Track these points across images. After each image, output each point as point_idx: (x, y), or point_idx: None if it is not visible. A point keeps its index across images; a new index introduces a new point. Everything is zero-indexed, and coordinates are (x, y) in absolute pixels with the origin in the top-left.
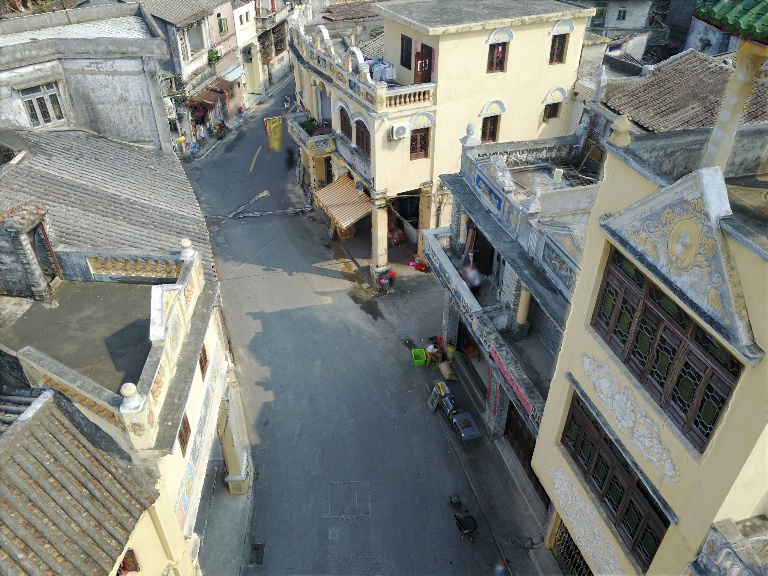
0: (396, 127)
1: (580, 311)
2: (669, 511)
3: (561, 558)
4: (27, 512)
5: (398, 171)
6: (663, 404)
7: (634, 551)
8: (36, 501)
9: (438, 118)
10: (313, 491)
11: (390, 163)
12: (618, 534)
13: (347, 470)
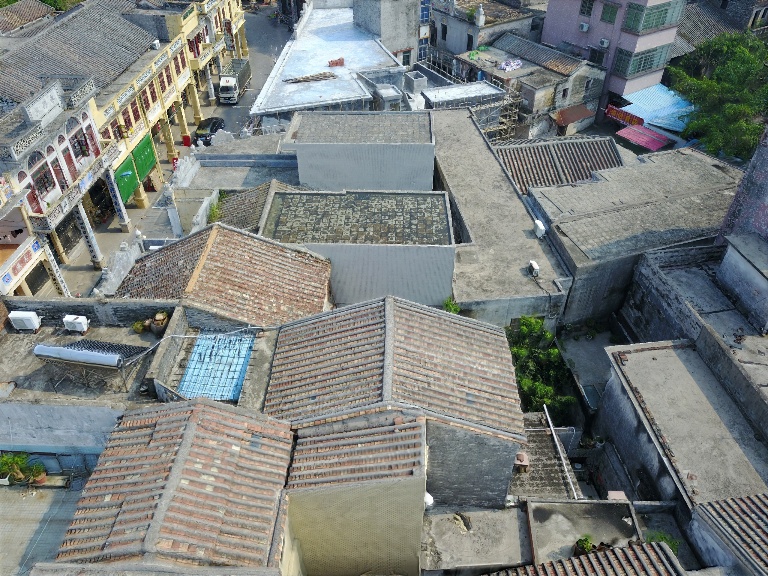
0: None
1: None
2: None
3: None
4: None
5: None
6: None
7: None
8: None
9: None
10: (255, 34)
11: None
12: None
13: (261, 31)
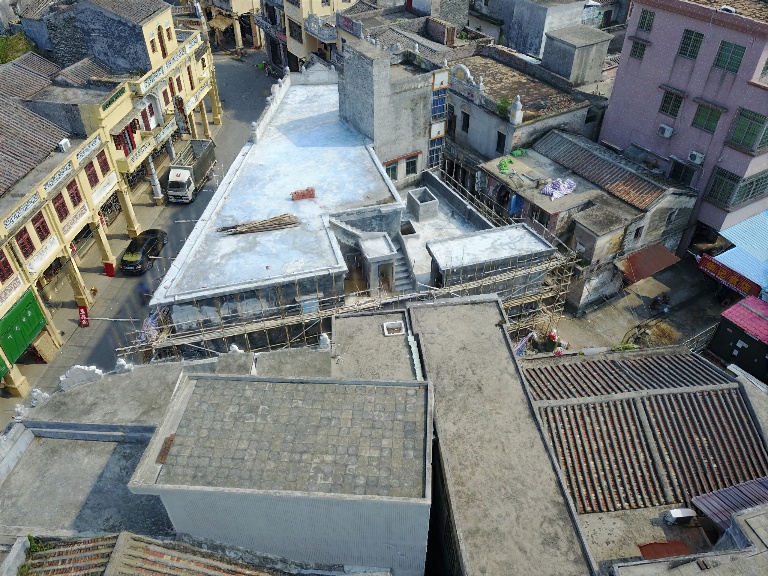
0: None
1: None
2: (300, 23)
3: None
4: None
5: (240, 4)
6: (296, 5)
7: None
8: None
9: None
10: None
11: (237, 1)
12: None
13: None
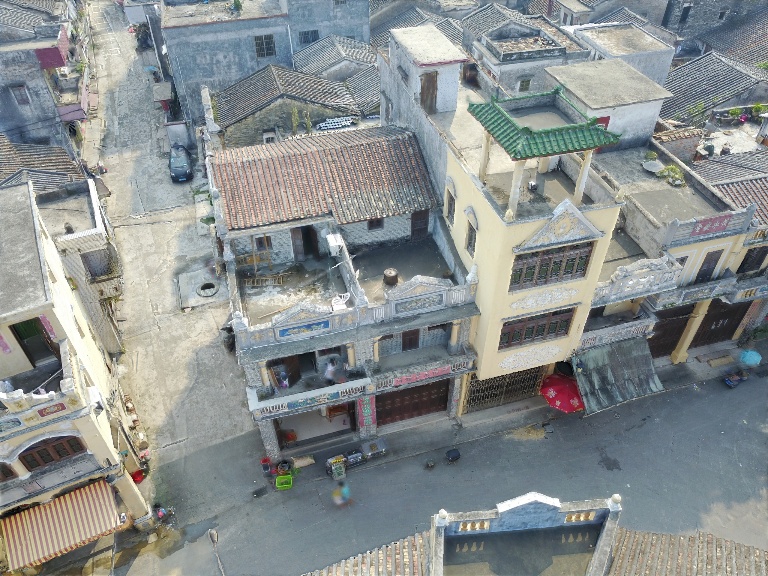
0: (100, 399)
1: (504, 292)
2: (578, 304)
3: (471, 408)
4: (674, 573)
5: None
6: (559, 280)
7: (557, 335)
8: (665, 572)
9: (82, 362)
10: None
11: None
12: (547, 340)
13: None
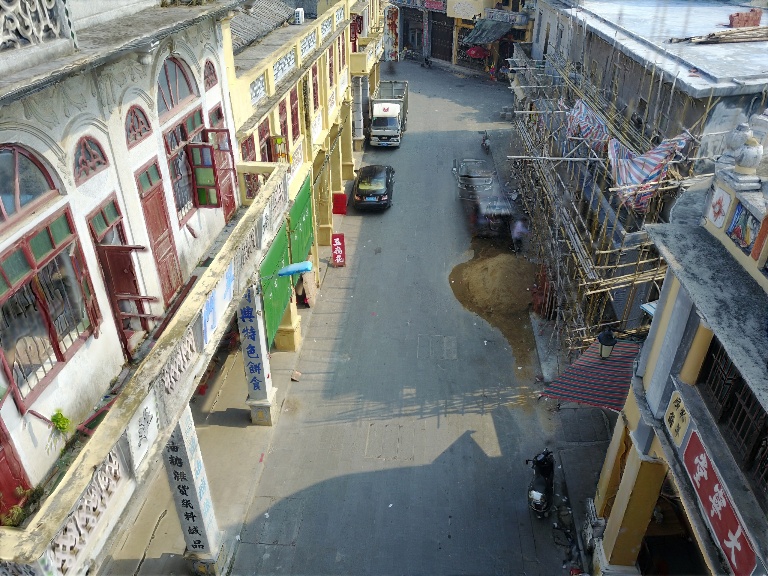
0: None
1: None
2: None
3: (459, 61)
4: None
5: None
6: None
7: None
8: None
9: None
10: None
11: None
12: None
13: None
